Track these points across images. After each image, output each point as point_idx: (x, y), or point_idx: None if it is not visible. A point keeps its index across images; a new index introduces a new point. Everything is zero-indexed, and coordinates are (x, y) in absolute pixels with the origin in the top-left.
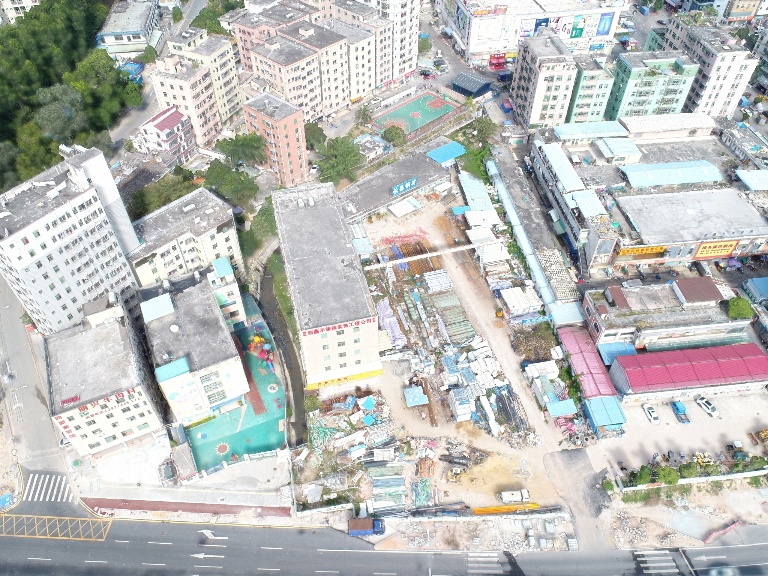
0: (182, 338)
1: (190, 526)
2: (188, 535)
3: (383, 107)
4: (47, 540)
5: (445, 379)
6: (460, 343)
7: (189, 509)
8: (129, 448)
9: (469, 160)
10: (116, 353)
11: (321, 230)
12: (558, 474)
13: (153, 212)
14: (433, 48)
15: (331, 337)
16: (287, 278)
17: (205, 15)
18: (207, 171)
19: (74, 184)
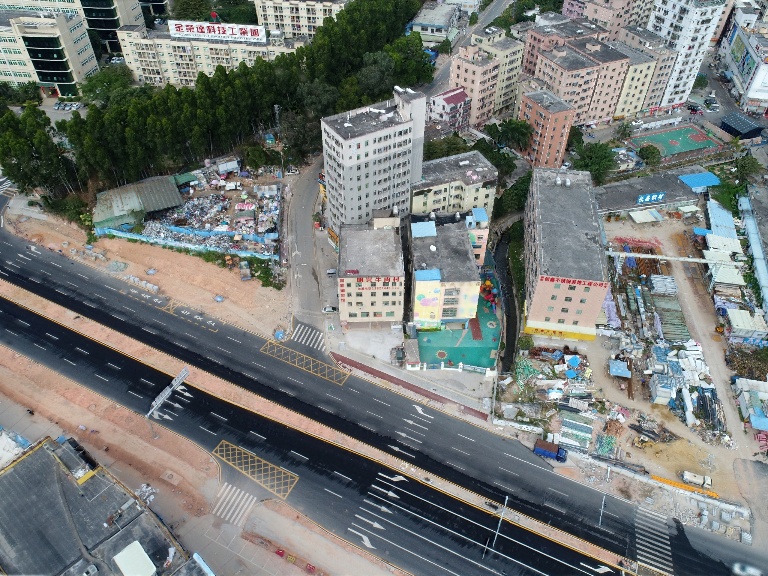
0: (437, 257)
1: (406, 399)
2: (403, 404)
3: (643, 130)
4: (303, 370)
5: (651, 364)
6: (673, 341)
7: (408, 387)
8: (371, 330)
9: (722, 191)
10: (389, 251)
11: (572, 206)
12: (746, 478)
13: (435, 159)
14: (707, 88)
15: (562, 289)
16: (531, 238)
17: (499, 22)
18: (473, 146)
19: (398, 116)
